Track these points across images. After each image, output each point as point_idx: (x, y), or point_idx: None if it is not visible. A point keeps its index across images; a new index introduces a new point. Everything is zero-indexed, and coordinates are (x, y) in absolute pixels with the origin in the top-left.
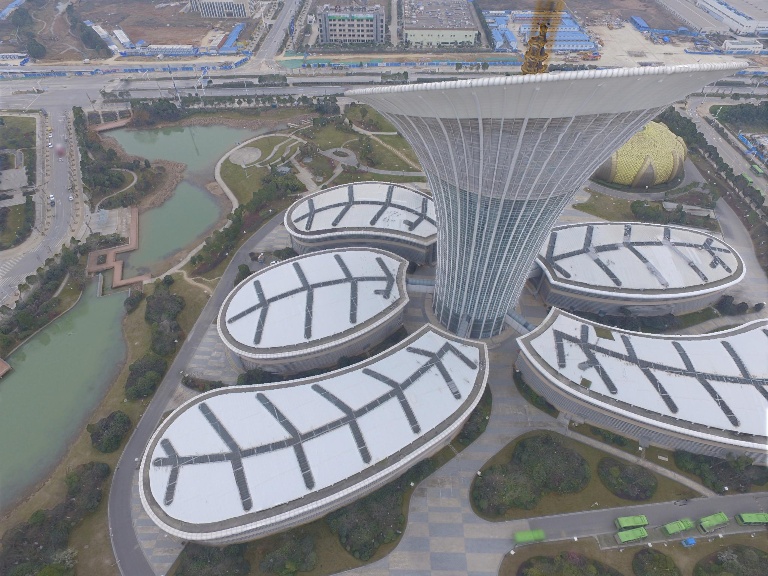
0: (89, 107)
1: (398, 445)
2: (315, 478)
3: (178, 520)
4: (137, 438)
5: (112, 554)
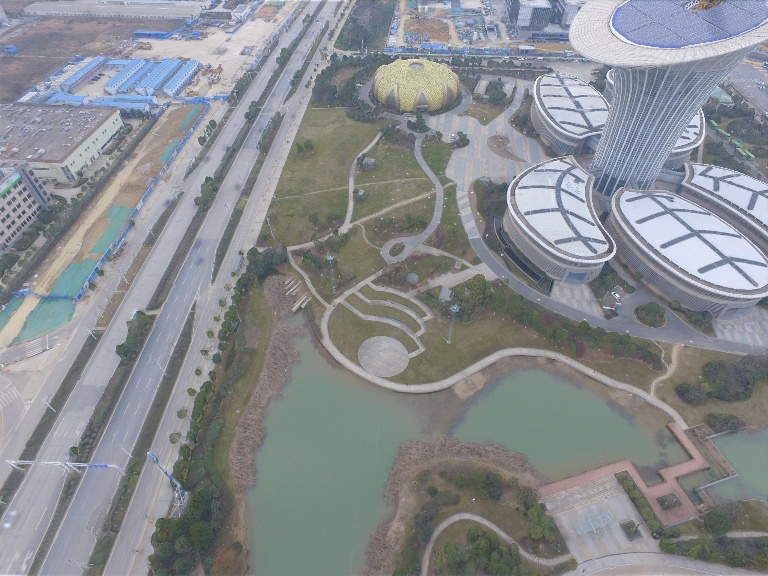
0: None
1: None
2: None
3: None
4: None
5: None
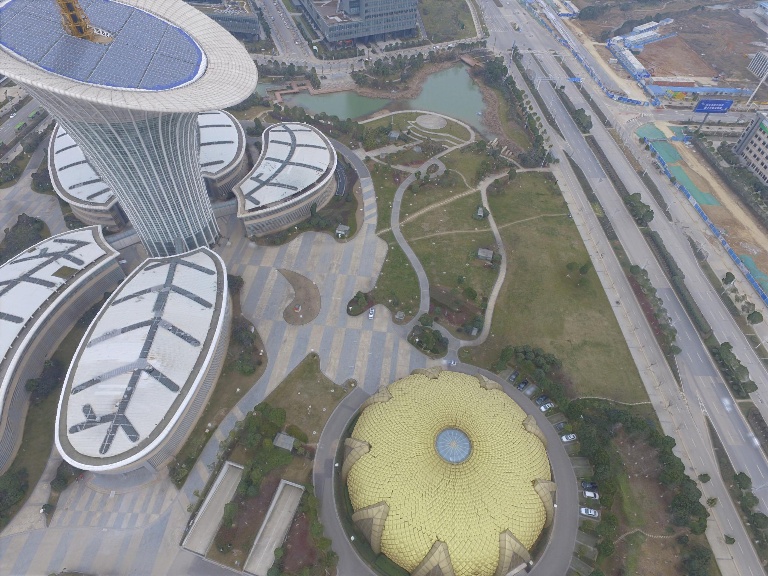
0: (500, 50)
1: (57, 163)
2: None
3: None
4: None
5: None
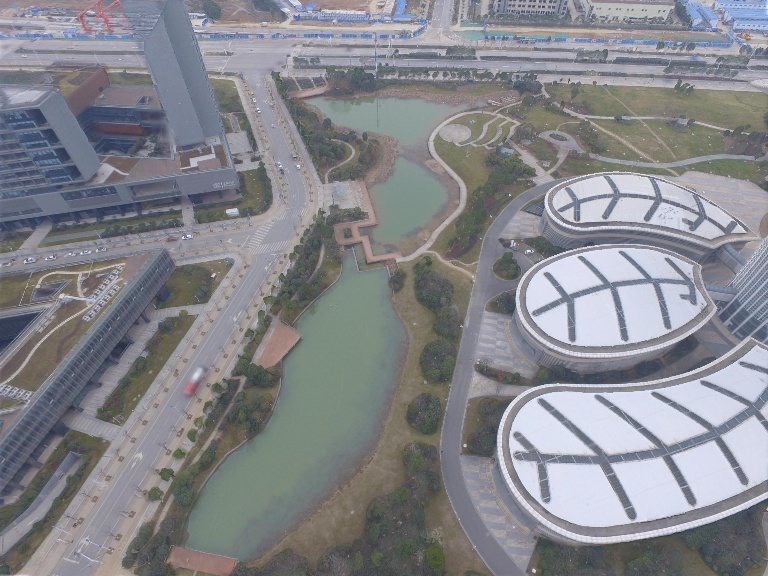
0: (281, 72)
1: None
2: (695, 495)
3: (563, 519)
4: (450, 422)
5: (467, 538)
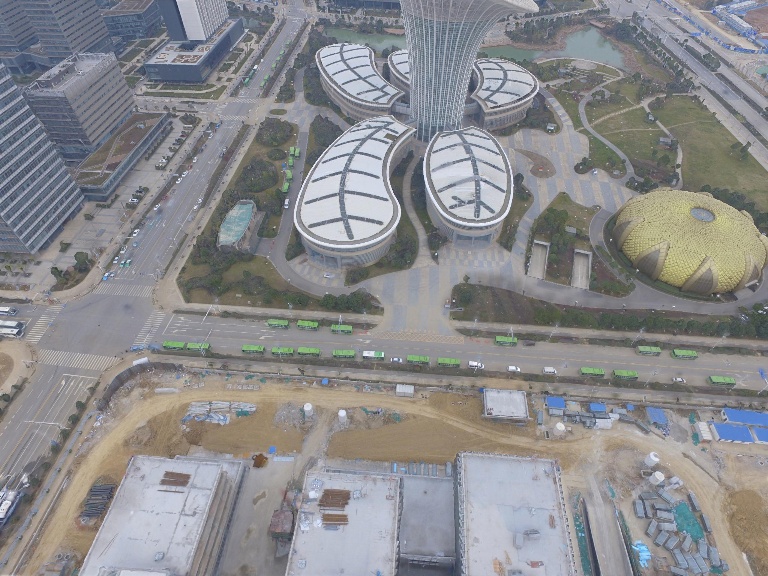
0: (620, 16)
1: None
2: None
3: None
4: None
5: None
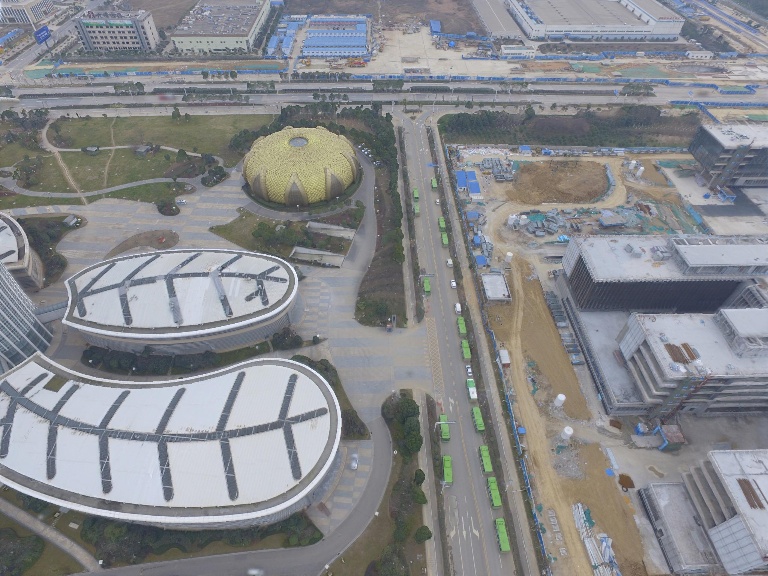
0: None
1: None
2: None
3: None
4: None
5: None
